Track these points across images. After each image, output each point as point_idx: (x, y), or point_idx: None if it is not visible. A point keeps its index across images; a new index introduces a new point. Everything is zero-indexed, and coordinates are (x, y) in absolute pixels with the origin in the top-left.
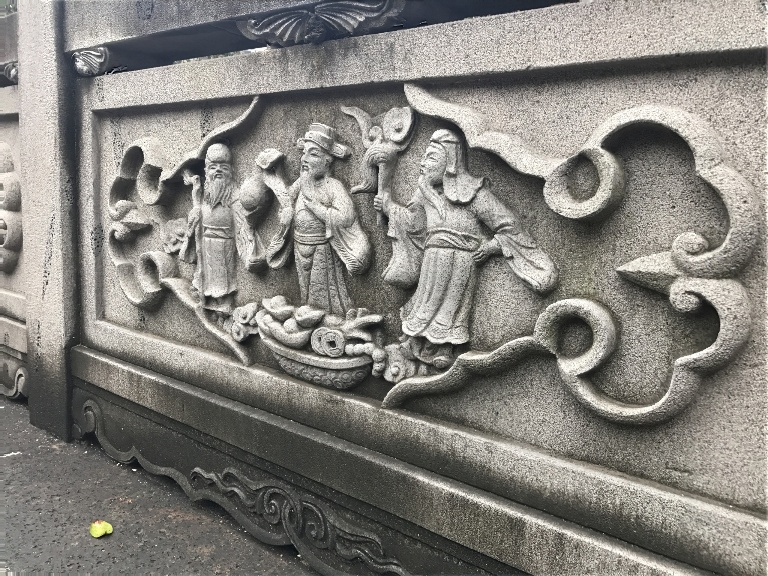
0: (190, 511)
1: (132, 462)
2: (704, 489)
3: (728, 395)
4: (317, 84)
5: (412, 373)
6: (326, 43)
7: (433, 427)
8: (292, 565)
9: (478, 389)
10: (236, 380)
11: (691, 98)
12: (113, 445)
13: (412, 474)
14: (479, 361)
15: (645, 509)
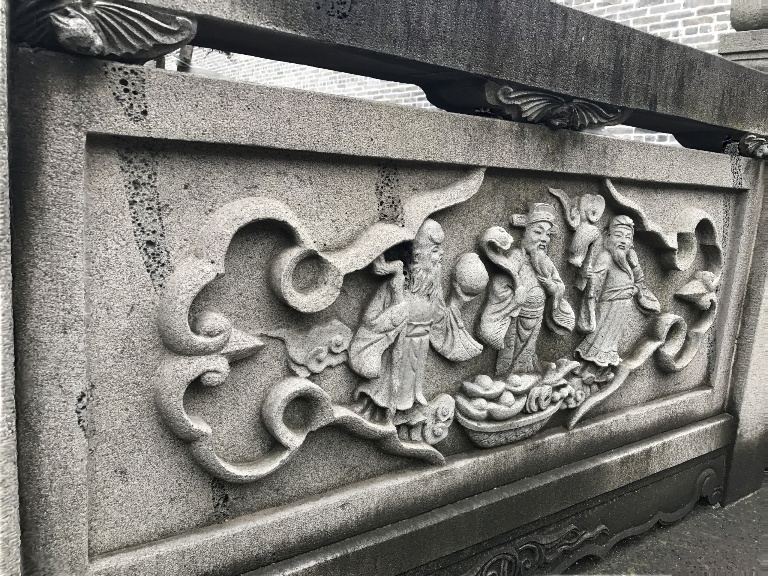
0: None
1: None
2: None
3: None
4: (550, 167)
5: (589, 394)
6: (561, 131)
7: (602, 424)
8: None
9: None
10: (435, 487)
11: (702, 205)
12: None
13: (602, 462)
14: (639, 366)
15: None
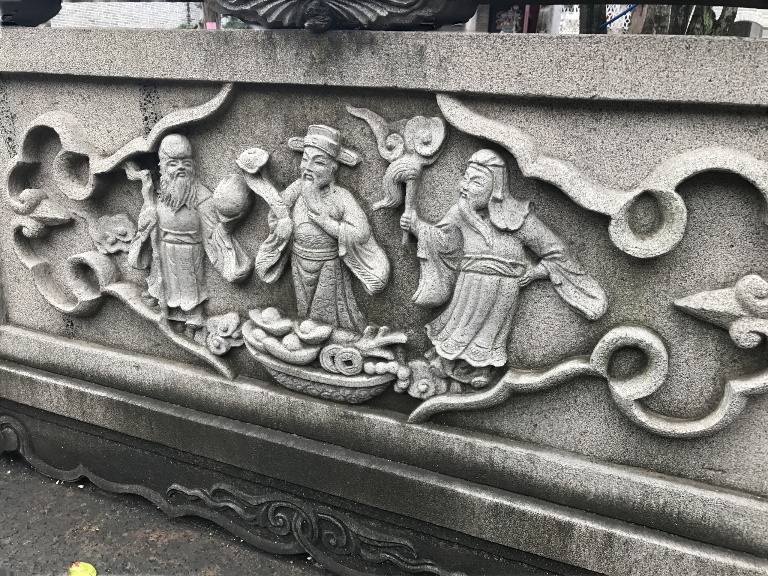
0: (170, 528)
1: (79, 480)
2: (736, 484)
3: (766, 410)
4: (319, 80)
5: (444, 390)
6: (331, 33)
7: (469, 441)
8: (307, 571)
9: (516, 404)
10: (218, 395)
11: (761, 145)
12: (49, 463)
13: (451, 487)
14: (529, 385)
15: (687, 506)
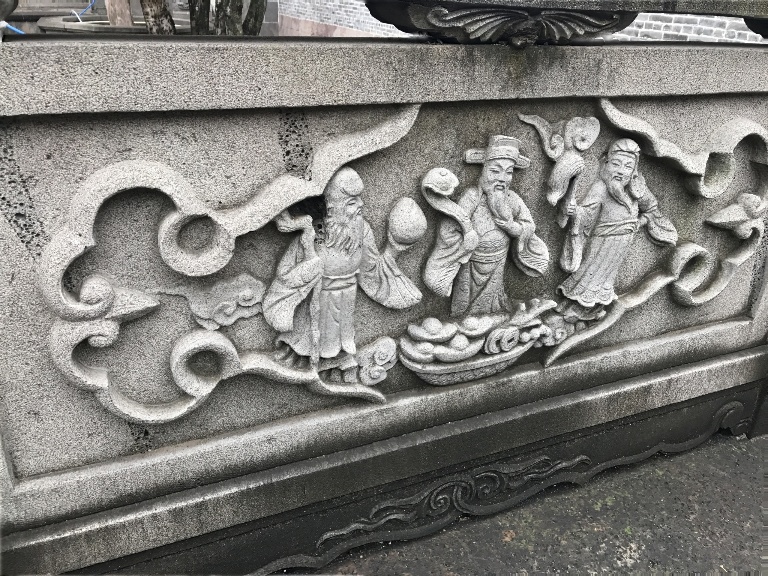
0: None
1: None
2: None
3: None
4: (513, 95)
5: (573, 332)
6: (529, 49)
7: (589, 361)
8: (461, 528)
9: None
10: (374, 423)
11: (757, 114)
12: None
13: (583, 399)
14: None
15: (699, 343)
